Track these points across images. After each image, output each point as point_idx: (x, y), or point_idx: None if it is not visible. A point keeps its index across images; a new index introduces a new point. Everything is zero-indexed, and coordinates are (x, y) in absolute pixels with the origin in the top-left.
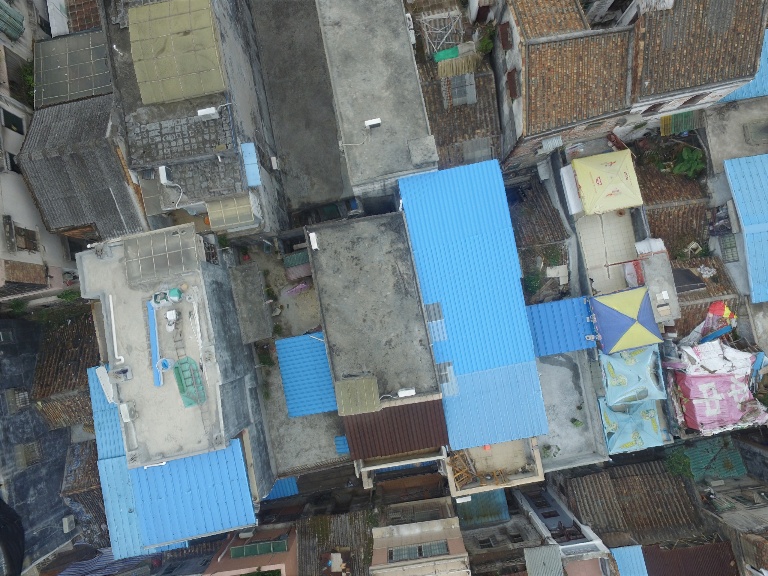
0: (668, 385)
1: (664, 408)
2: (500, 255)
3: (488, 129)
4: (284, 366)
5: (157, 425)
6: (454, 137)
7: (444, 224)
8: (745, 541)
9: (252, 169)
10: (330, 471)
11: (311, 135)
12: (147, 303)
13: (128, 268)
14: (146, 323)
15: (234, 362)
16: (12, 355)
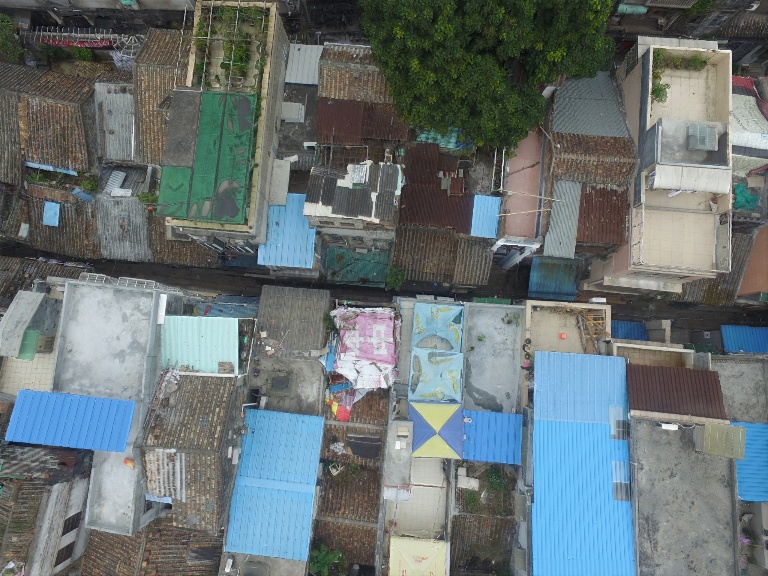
0: None
1: None
2: (550, 532)
3: None
4: None
5: None
6: None
7: None
8: None
9: None
10: None
11: None
12: None
13: None
14: None
15: None
16: None
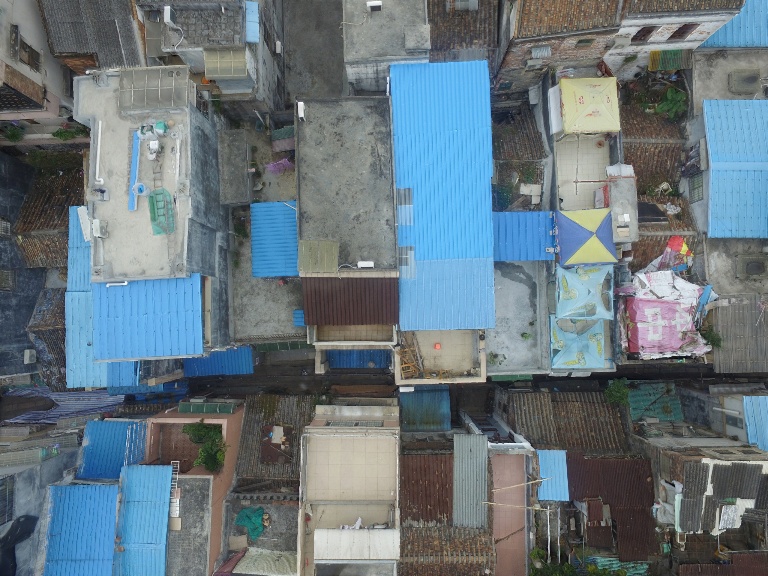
0: (618, 311)
1: (612, 337)
2: (475, 152)
3: (486, 41)
4: (255, 228)
5: (125, 247)
6: (452, 44)
7: (427, 115)
8: (663, 456)
9: (253, 27)
10: (289, 368)
11: (320, 36)
12: (134, 133)
13: (121, 97)
14: (130, 152)
15: (208, 210)
16: (1, 186)
